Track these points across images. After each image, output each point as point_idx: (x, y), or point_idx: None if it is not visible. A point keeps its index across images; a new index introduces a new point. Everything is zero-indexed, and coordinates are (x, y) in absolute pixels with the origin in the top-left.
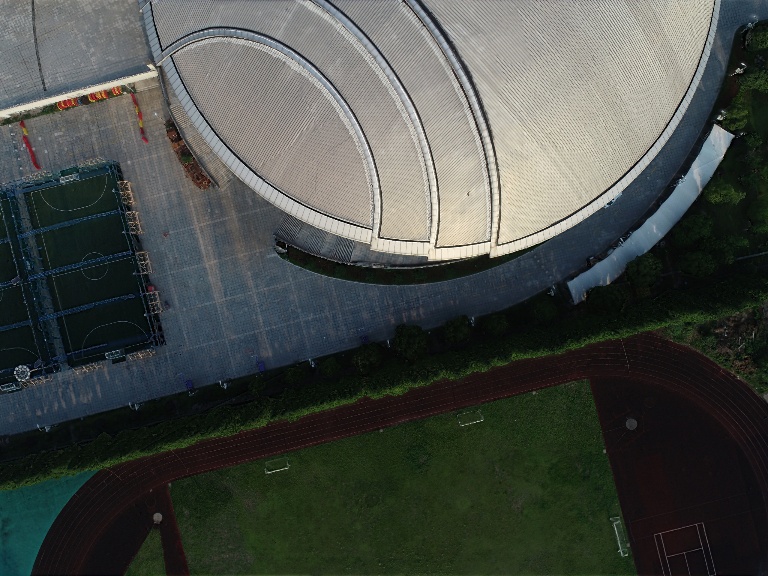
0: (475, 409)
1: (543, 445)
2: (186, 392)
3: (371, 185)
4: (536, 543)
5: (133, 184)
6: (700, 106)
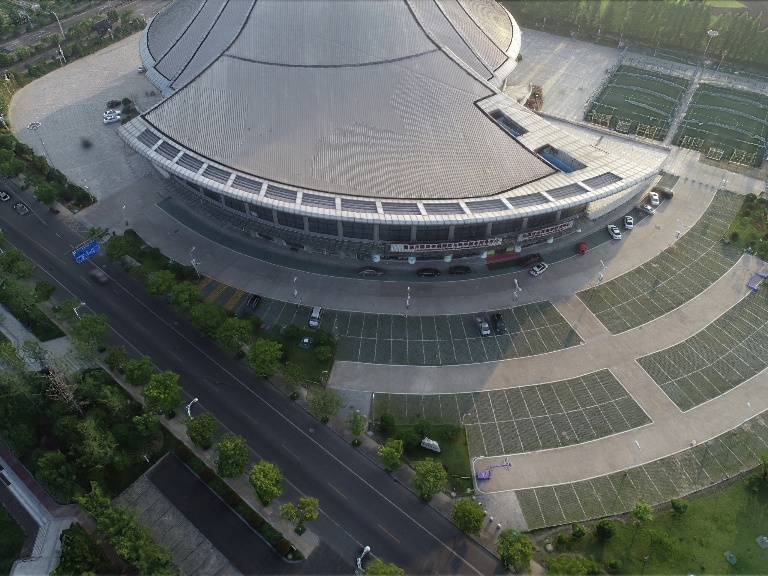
0: None
1: None
2: None
3: None
4: None
5: None
6: None
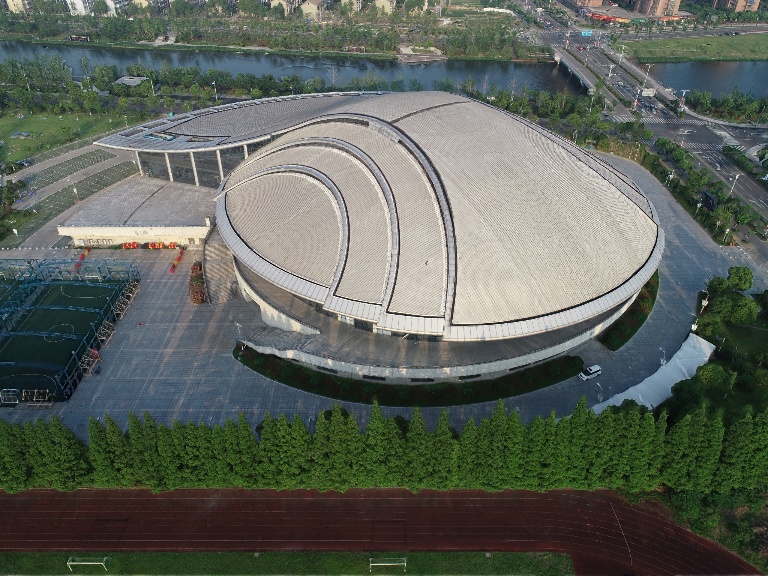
0: (398, 556)
1: None
2: None
3: None
4: None
5: (141, 292)
6: (675, 329)
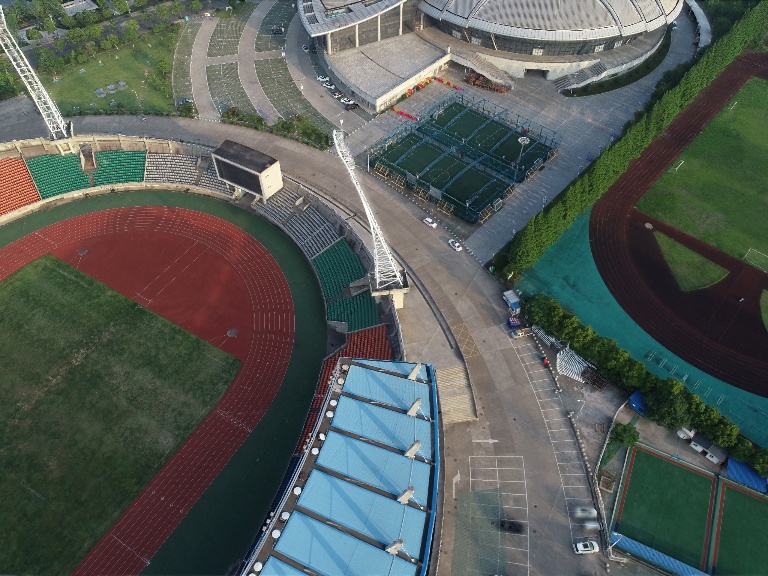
0: (727, 106)
1: None
2: (592, 163)
3: (603, 5)
4: None
5: None
6: None
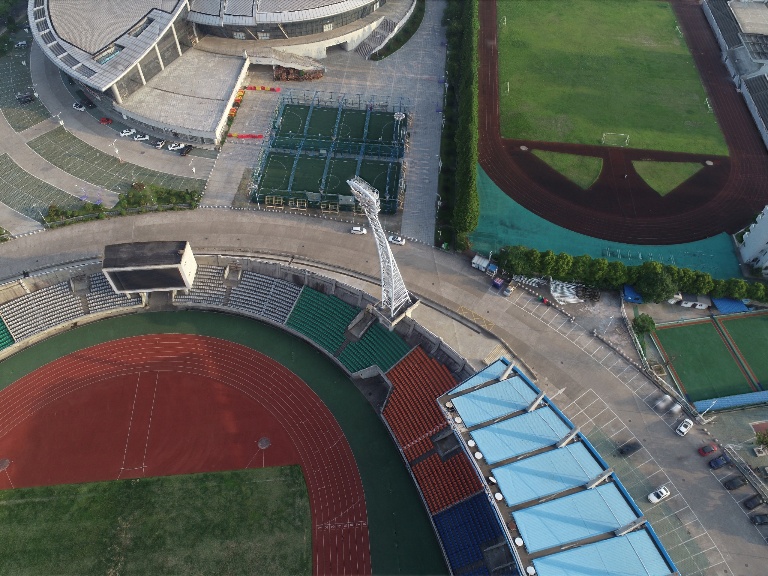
0: (499, 22)
1: (527, 8)
2: None
3: None
4: (581, 20)
5: None
6: None
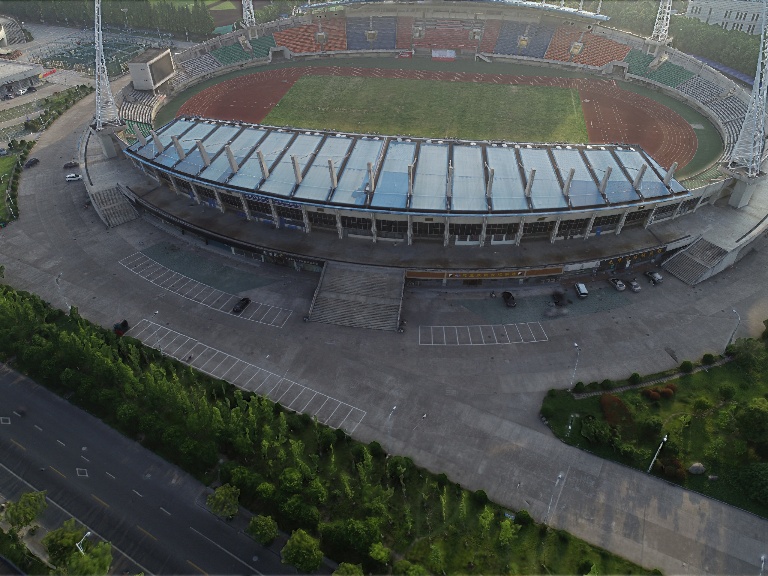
0: None
1: None
2: None
3: None
4: None
5: None
6: None
